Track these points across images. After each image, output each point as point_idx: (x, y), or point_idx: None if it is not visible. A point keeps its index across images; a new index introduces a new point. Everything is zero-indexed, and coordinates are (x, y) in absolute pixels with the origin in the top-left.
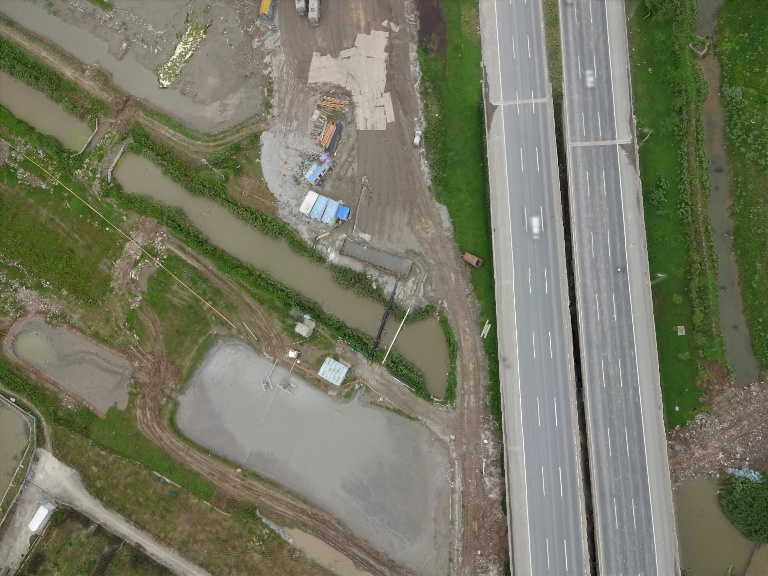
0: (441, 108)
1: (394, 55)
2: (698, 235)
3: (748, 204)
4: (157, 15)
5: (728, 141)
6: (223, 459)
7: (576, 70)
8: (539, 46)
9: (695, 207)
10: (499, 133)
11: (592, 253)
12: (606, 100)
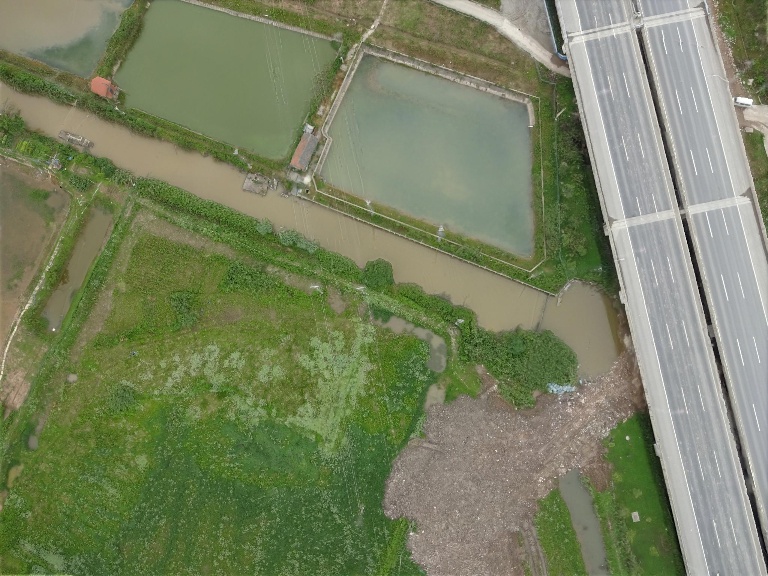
0: None
1: None
2: None
3: None
4: None
5: None
6: None
7: None
8: None
9: None
10: None
11: None
12: None
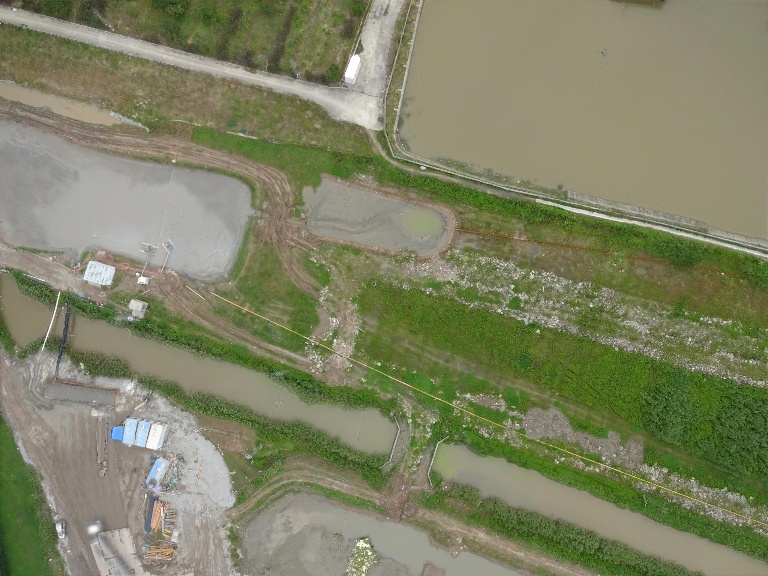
0: (47, 569)
1: None
2: None
3: None
4: None
5: None
6: (192, 167)
7: None
8: None
9: None
10: None
11: None
12: None
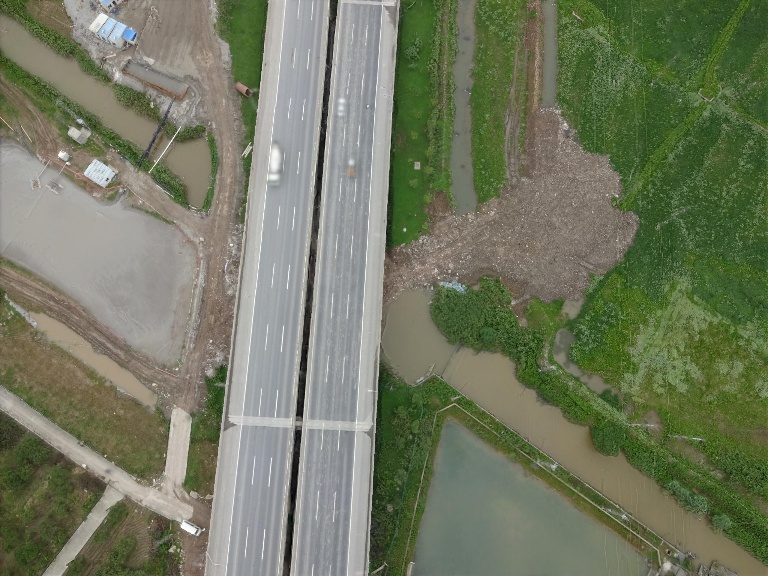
0: None
1: None
2: (441, 87)
3: (486, 67)
4: None
5: (477, 15)
6: None
7: None
8: None
9: (441, 64)
10: None
11: (347, 91)
12: None
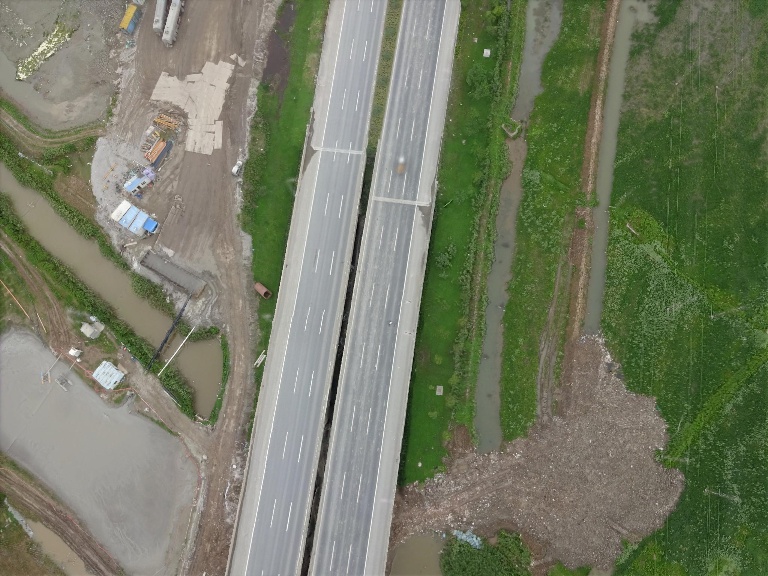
0: (267, 144)
1: (235, 87)
2: (472, 303)
3: (524, 281)
4: (30, 12)
5: (519, 220)
6: None
7: (395, 130)
8: (367, 102)
9: (475, 276)
10: (312, 176)
11: (370, 303)
12: (415, 162)
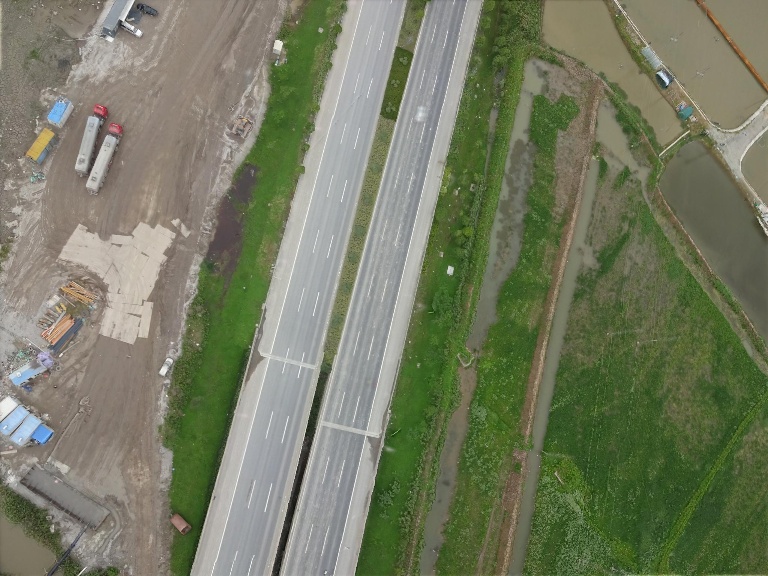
0: (205, 338)
1: (173, 262)
2: (409, 547)
3: (460, 525)
4: None
5: (462, 458)
6: None
7: (352, 345)
8: (326, 308)
9: (415, 518)
10: (256, 388)
11: (306, 548)
12: (370, 386)
